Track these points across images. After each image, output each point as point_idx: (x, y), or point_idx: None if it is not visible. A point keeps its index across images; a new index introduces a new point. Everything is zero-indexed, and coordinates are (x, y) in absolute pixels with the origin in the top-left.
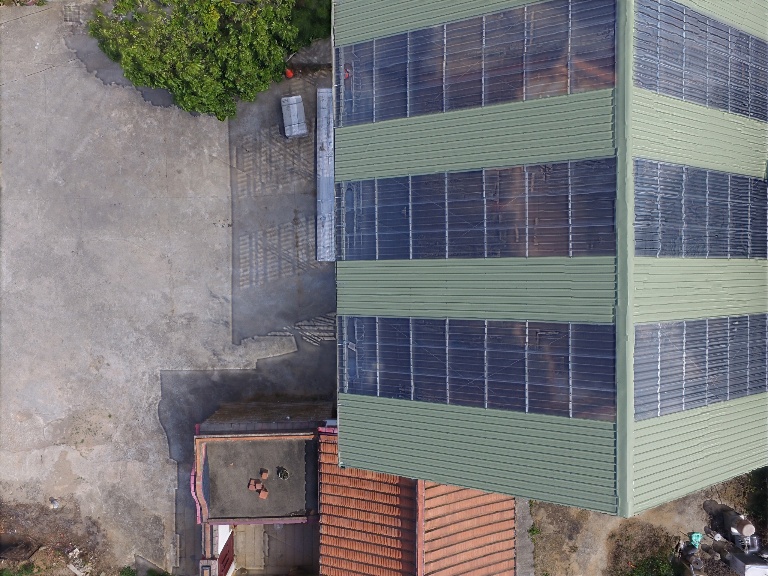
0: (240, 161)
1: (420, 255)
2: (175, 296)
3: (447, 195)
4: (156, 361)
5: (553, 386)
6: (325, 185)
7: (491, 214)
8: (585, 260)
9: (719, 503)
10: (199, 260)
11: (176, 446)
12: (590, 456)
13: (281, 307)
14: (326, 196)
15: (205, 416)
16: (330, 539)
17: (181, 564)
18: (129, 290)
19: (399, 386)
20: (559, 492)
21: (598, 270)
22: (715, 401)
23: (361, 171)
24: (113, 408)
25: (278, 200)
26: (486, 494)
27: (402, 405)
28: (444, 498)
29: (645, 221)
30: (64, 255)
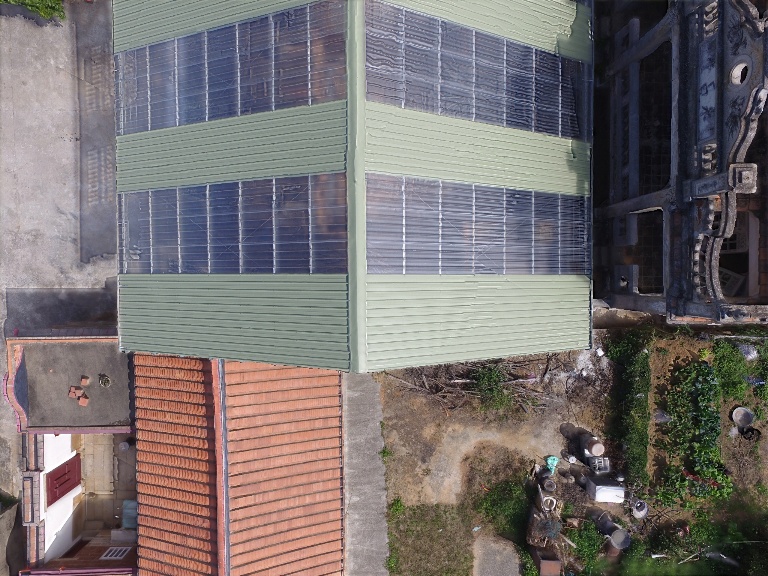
0: (88, 73)
1: (185, 121)
2: (21, 212)
3: (207, 55)
4: (1, 279)
5: (295, 243)
6: None
7: (243, 69)
8: (322, 107)
9: (576, 426)
10: (46, 175)
11: None
12: (327, 312)
13: (131, 224)
14: None
15: None
16: (145, 444)
17: None
18: None
19: (169, 260)
20: (302, 353)
21: (333, 116)
22: (486, 272)
23: (135, 39)
24: None
25: None
26: (306, 399)
27: (171, 280)
28: (253, 397)
29: (382, 65)
30: None
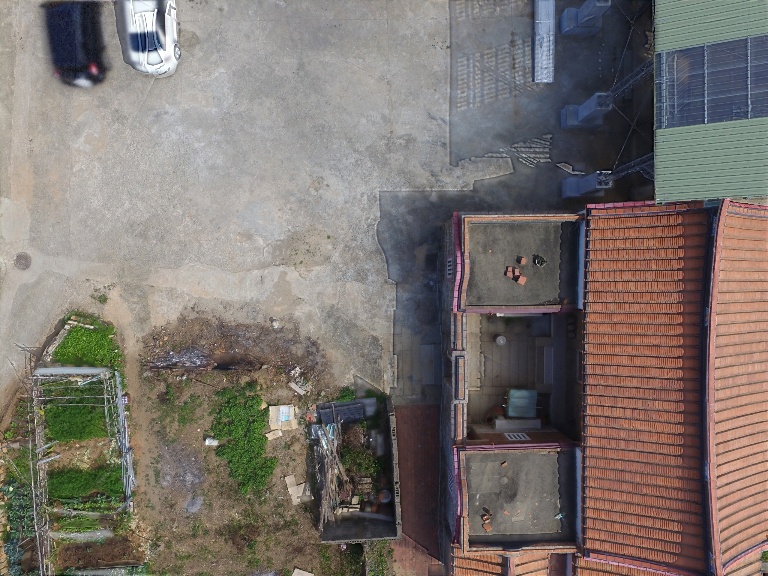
0: None
1: None
2: (394, 117)
3: None
4: (375, 182)
5: None
6: (544, 6)
7: None
8: None
9: None
10: (418, 82)
11: (394, 266)
12: None
13: (498, 129)
14: (544, 17)
15: (423, 237)
16: (598, 316)
17: (398, 384)
18: (349, 111)
19: (733, 108)
20: None
21: None
22: None
23: None
24: (332, 229)
25: (495, 22)
26: (750, 271)
27: (736, 126)
28: (724, 263)
29: None
30: (285, 76)
